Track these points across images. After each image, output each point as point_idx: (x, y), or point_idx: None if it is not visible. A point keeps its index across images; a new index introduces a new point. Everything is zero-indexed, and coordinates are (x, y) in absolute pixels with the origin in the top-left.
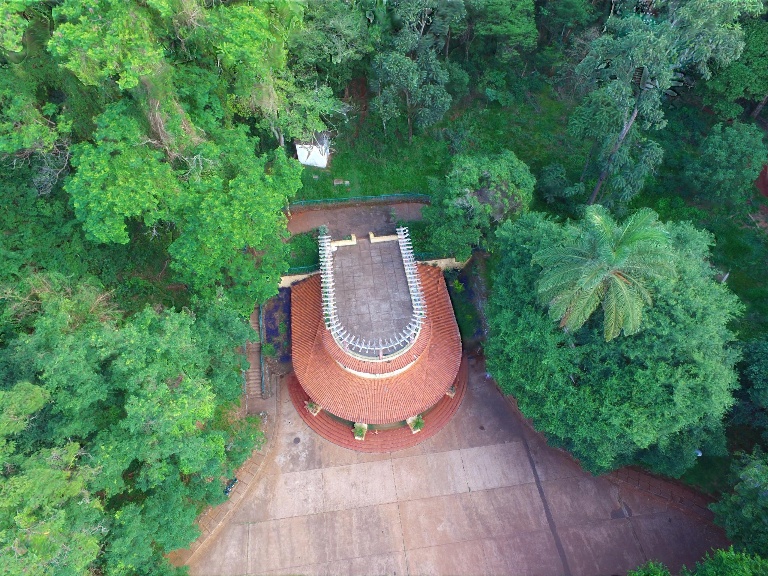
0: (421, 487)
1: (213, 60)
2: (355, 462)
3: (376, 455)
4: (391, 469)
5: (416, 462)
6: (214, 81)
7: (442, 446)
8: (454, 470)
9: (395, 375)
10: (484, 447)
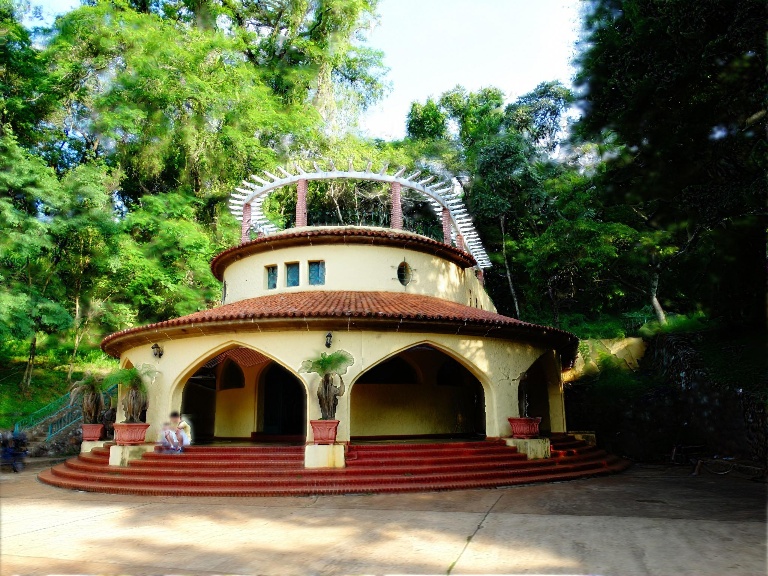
0: (147, 540)
1: (281, 83)
2: (26, 496)
3: (115, 495)
4: (109, 509)
5: (235, 510)
6: (268, 72)
7: (403, 503)
8: (401, 534)
9: (328, 291)
10: (647, 517)
